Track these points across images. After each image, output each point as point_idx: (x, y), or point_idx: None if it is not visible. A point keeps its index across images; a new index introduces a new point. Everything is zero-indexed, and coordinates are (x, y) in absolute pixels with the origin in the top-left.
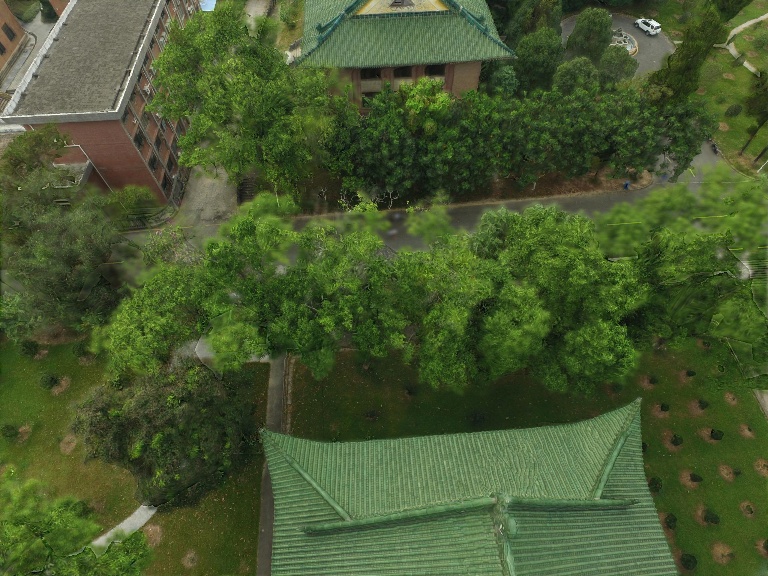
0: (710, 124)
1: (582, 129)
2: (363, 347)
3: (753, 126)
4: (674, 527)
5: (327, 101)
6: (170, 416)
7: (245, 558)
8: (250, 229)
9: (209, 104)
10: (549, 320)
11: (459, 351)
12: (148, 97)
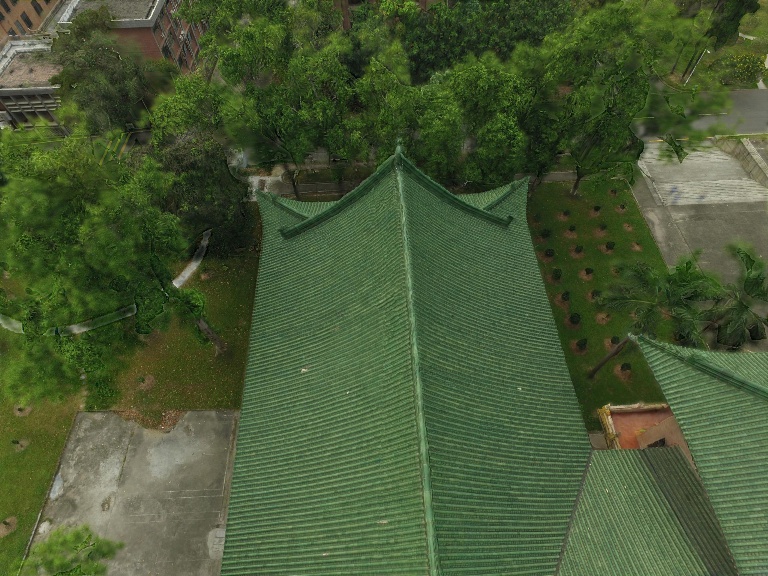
0: (629, 29)
1: (523, 32)
2: (332, 149)
3: (678, 44)
4: (567, 299)
5: (316, 3)
6: (192, 161)
7: (243, 316)
8: (250, 37)
9: (223, 5)
10: (468, 127)
11: (402, 152)
12: (173, 20)
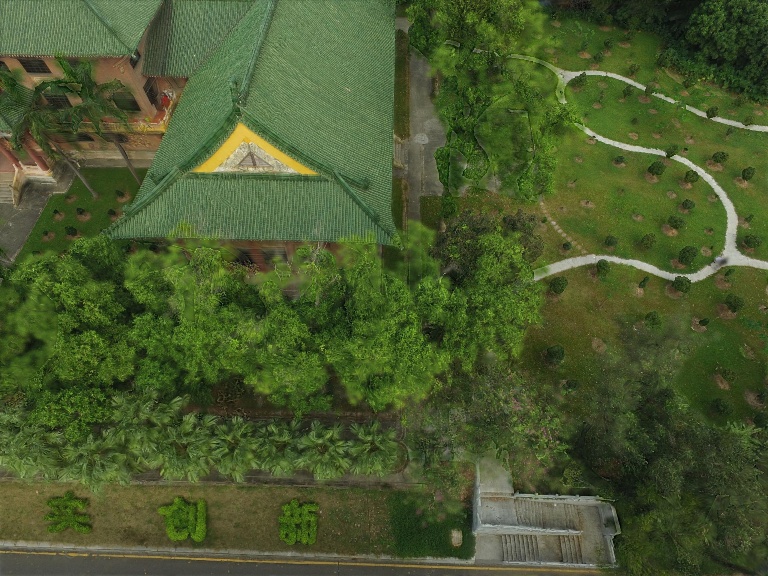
0: None
1: None
2: None
3: None
4: None
5: None
6: None
7: None
8: None
9: None
10: None
11: None
12: None
